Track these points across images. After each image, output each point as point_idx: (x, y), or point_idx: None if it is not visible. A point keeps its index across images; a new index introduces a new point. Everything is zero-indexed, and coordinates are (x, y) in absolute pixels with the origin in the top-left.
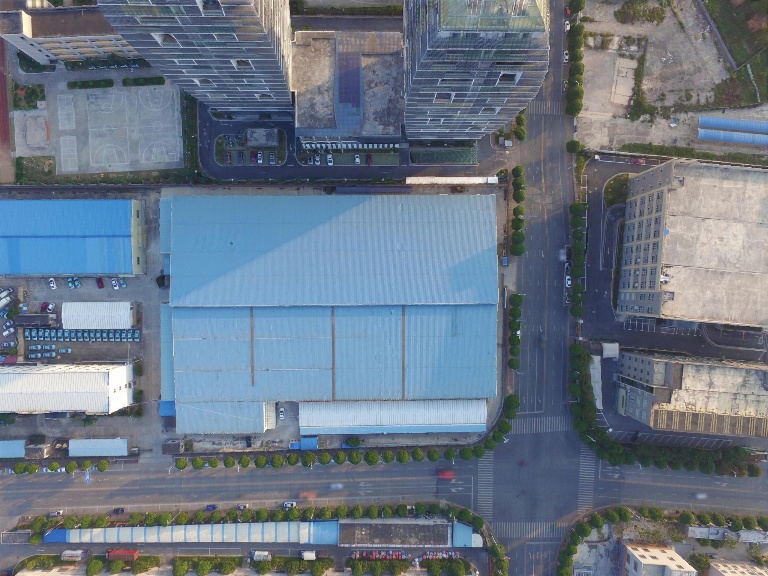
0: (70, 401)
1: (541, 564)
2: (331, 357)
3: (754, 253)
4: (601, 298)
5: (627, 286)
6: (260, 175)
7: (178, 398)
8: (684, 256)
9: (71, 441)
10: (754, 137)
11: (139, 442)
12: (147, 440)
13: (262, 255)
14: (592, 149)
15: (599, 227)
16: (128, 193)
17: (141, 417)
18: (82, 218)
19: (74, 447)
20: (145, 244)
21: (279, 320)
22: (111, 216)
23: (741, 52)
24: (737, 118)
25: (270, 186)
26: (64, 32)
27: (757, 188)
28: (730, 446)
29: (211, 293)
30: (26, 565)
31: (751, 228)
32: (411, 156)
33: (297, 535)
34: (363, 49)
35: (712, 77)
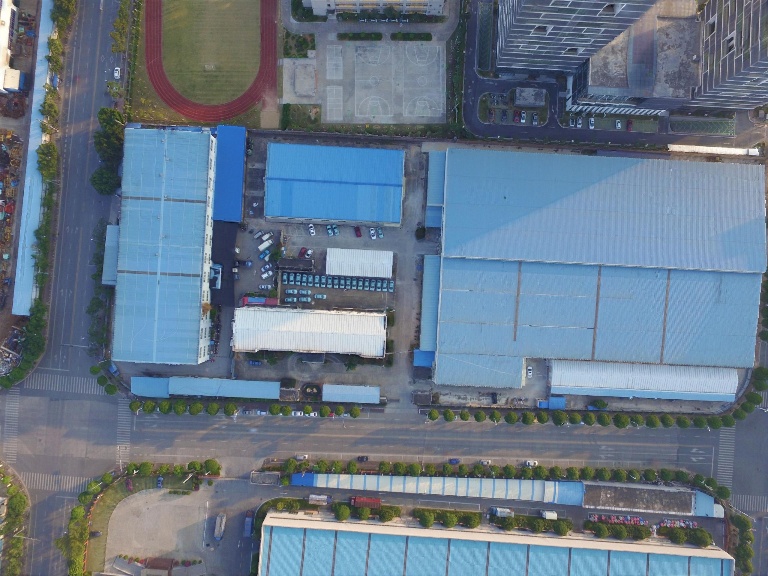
0: (346, 343)
1: None
2: (594, 317)
3: None
4: None
5: None
6: (521, 135)
7: (440, 348)
8: None
9: (325, 386)
10: None
11: (386, 392)
12: (394, 390)
13: (535, 211)
14: None
15: None
16: (390, 145)
17: (390, 367)
18: (355, 165)
19: (328, 392)
20: None
21: (546, 277)
22: (383, 165)
23: None
24: None
25: (531, 146)
26: None
27: None
28: None
29: (484, 245)
30: (276, 506)
31: None
32: None
33: (541, 494)
34: (659, 12)
35: None
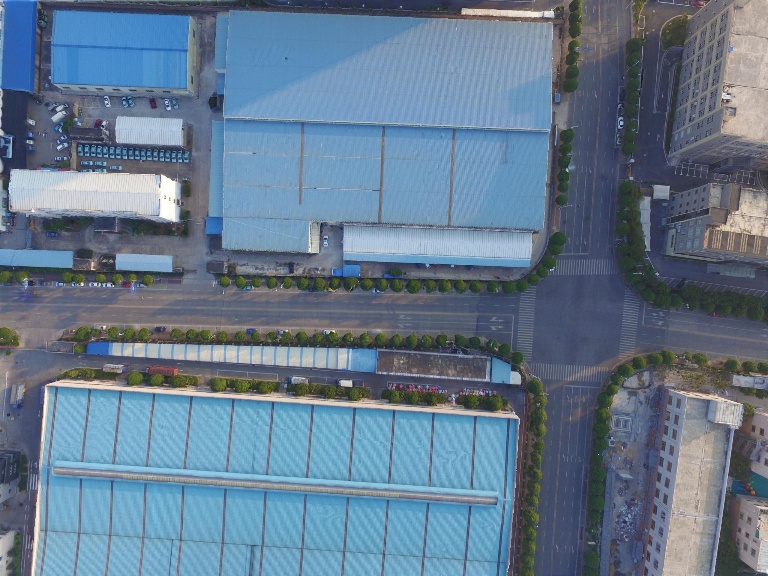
0: (122, 202)
1: (579, 408)
2: (379, 178)
3: None
4: (653, 141)
5: (682, 124)
6: (315, 2)
7: (226, 212)
8: (747, 76)
9: (118, 255)
10: None
11: (183, 263)
12: (191, 261)
13: (316, 71)
14: None
15: (655, 69)
16: None
17: (187, 237)
18: (140, 31)
19: (121, 260)
20: (199, 67)
21: (329, 138)
22: (168, 30)
23: None
24: None
25: None
26: None
27: None
28: None
29: (264, 106)
30: (69, 372)
31: None
32: None
33: (335, 361)
34: None
35: None
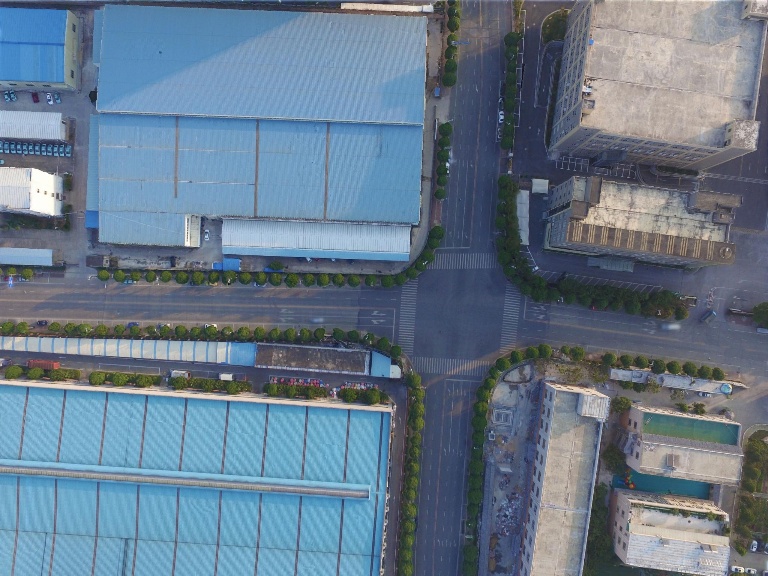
0: None
1: (460, 402)
2: (254, 172)
3: (682, 70)
4: (534, 135)
5: (558, 118)
6: None
7: (102, 206)
8: (609, 69)
9: None
10: None
11: (66, 257)
12: (74, 255)
13: (190, 65)
14: None
15: (535, 63)
16: None
17: (69, 231)
18: (18, 25)
19: (1, 254)
20: (81, 61)
21: (204, 132)
22: (46, 24)
23: None
24: None
25: None
26: None
27: (688, 3)
28: (659, 291)
29: (137, 99)
30: None
31: (680, 44)
32: None
33: (215, 355)
34: None
35: None
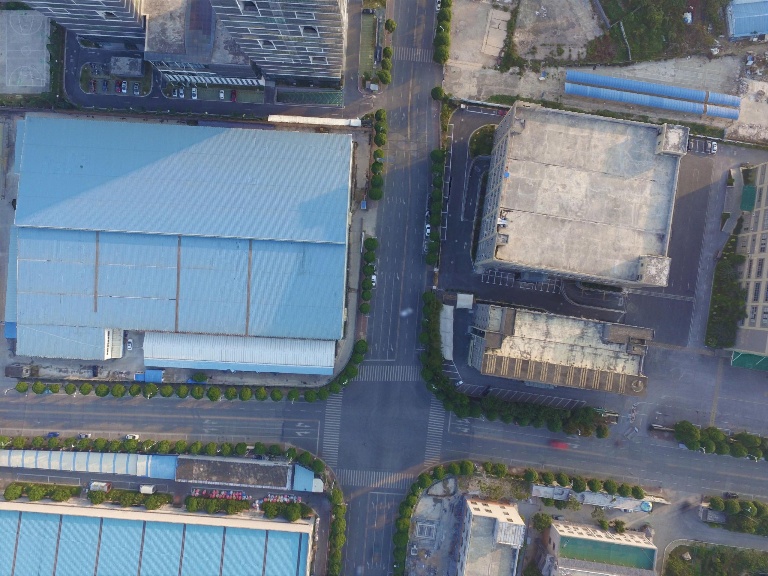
0: None
1: (384, 515)
2: (176, 287)
3: (597, 203)
4: (460, 249)
5: (482, 236)
6: (124, 105)
7: (20, 319)
8: (525, 201)
9: None
10: (621, 94)
11: None
12: None
13: (111, 180)
14: (458, 98)
15: (463, 177)
16: None
17: None
18: None
19: None
20: (5, 167)
21: (125, 247)
22: None
23: (615, 10)
24: (608, 76)
25: (133, 116)
26: None
27: (603, 137)
28: (582, 407)
29: (57, 214)
30: None
31: (595, 177)
32: (280, 96)
33: (135, 467)
34: None
35: (585, 33)
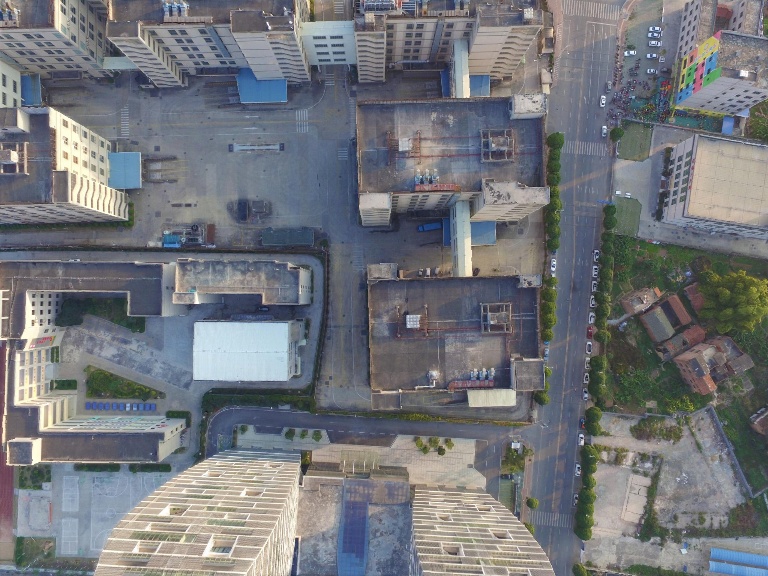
0: None
1: None
2: None
3: None
4: None
5: None
6: None
7: None
8: None
9: None
10: (767, 575)
11: None
12: None
13: None
14: (599, 572)
15: None
16: None
17: None
18: None
19: None
20: None
21: None
22: None
23: (758, 479)
24: (750, 546)
25: None
26: (73, 455)
27: None
28: None
29: None
30: None
31: None
32: None
33: None
34: (371, 498)
35: (727, 501)
